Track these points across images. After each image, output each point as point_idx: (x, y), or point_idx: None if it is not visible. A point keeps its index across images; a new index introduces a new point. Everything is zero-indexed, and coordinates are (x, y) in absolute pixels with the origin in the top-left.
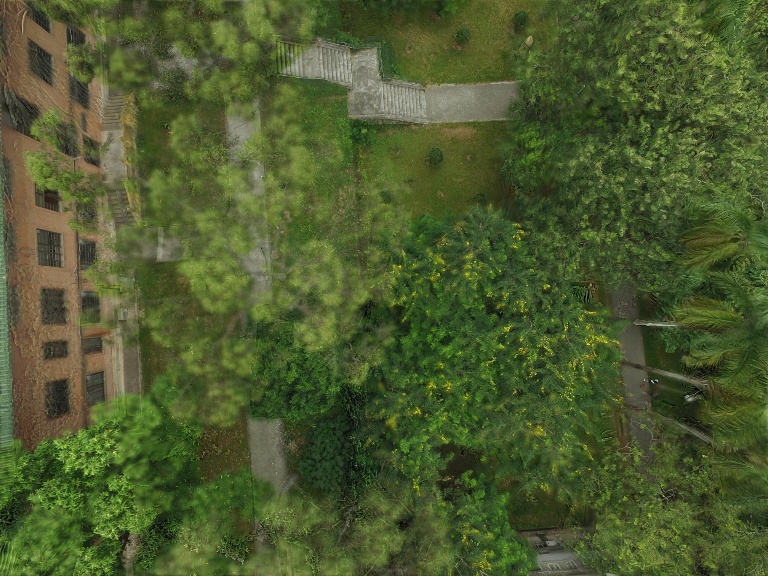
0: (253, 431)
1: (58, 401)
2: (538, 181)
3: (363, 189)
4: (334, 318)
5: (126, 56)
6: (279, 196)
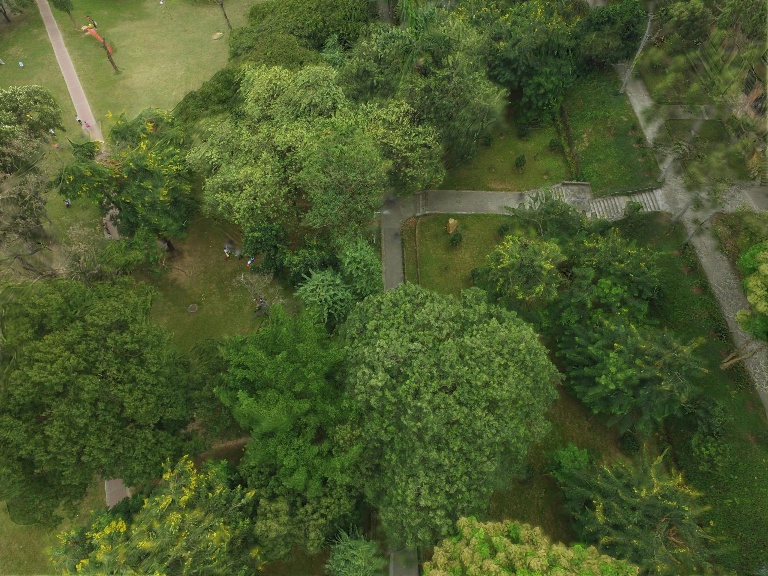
0: None
1: (737, 8)
2: None
3: (569, 153)
4: None
5: None
6: None
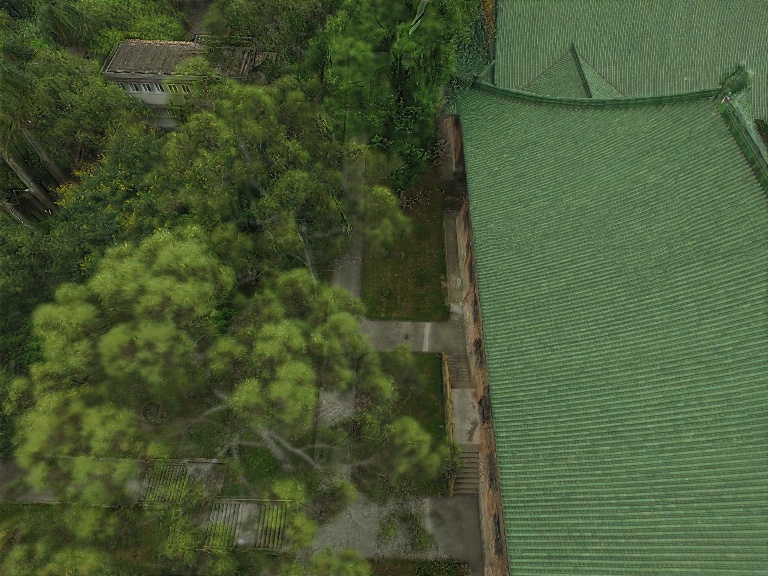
0: (360, 201)
1: None
2: (49, 320)
3: (236, 390)
4: (285, 272)
5: (461, 547)
6: (309, 368)
